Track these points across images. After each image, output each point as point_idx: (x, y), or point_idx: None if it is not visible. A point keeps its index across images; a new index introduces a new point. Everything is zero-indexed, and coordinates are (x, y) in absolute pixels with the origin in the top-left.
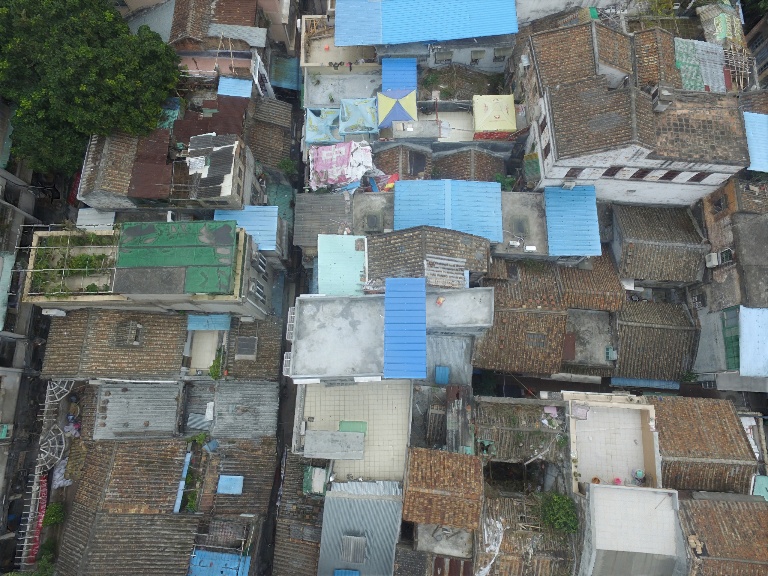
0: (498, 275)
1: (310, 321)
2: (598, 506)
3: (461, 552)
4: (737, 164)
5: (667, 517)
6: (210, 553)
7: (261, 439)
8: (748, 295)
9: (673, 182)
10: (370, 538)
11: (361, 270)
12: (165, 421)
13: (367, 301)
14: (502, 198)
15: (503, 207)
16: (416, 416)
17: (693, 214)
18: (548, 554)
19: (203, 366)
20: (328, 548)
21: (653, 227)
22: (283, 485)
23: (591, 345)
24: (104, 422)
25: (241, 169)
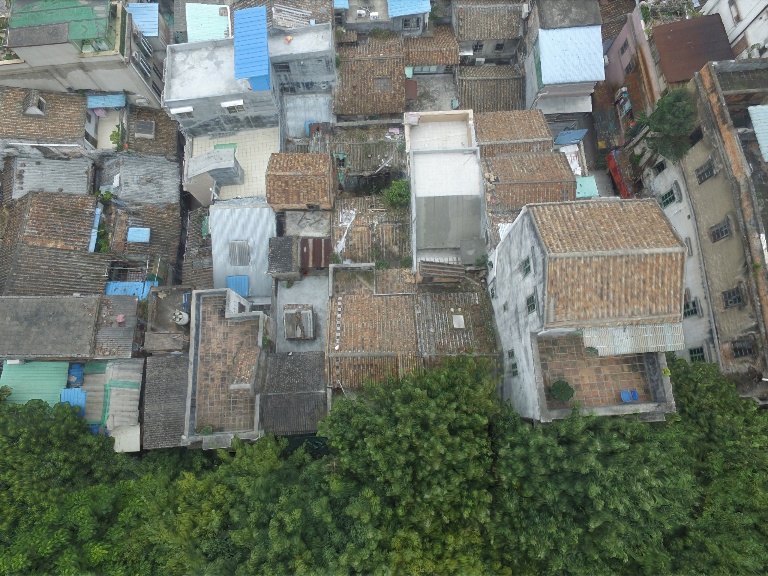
0: (349, 39)
1: (181, 65)
2: (418, 167)
3: (322, 233)
4: None
5: (473, 169)
6: (123, 282)
7: (166, 205)
8: (544, 19)
9: None
10: (253, 245)
11: (225, 30)
12: (77, 189)
13: (228, 46)
14: None
15: None
16: None
17: None
18: (390, 223)
19: (108, 147)
20: (219, 259)
21: None
22: (187, 239)
23: (439, 101)
24: (21, 186)
25: None
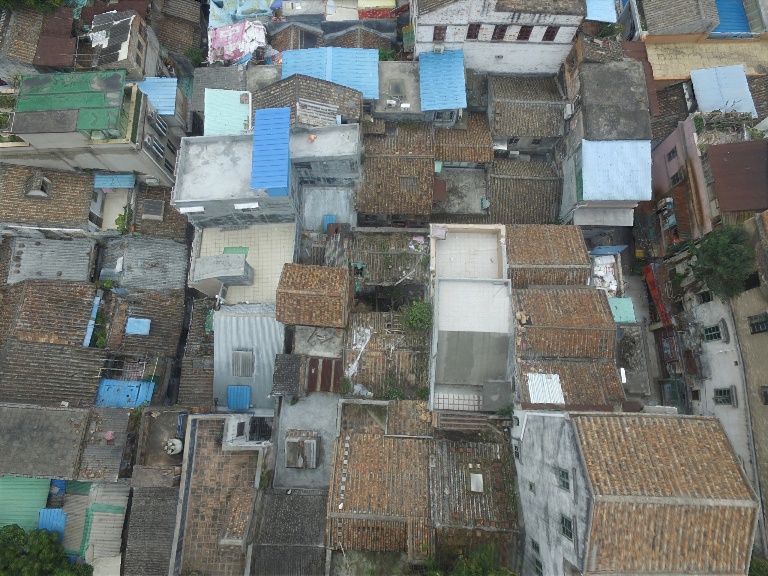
0: (377, 130)
1: (195, 159)
2: (443, 296)
3: (333, 354)
4: (576, 13)
5: (503, 303)
6: (117, 381)
7: (169, 292)
8: (589, 129)
9: (530, 42)
10: (258, 355)
11: (245, 119)
12: (77, 272)
13: (247, 141)
14: (383, 66)
15: (383, 74)
16: (305, 258)
17: (558, 80)
18: (407, 349)
19: (113, 226)
20: (221, 366)
21: (521, 91)
22: (190, 331)
23: (468, 198)
24: (18, 269)
25: (141, 43)
